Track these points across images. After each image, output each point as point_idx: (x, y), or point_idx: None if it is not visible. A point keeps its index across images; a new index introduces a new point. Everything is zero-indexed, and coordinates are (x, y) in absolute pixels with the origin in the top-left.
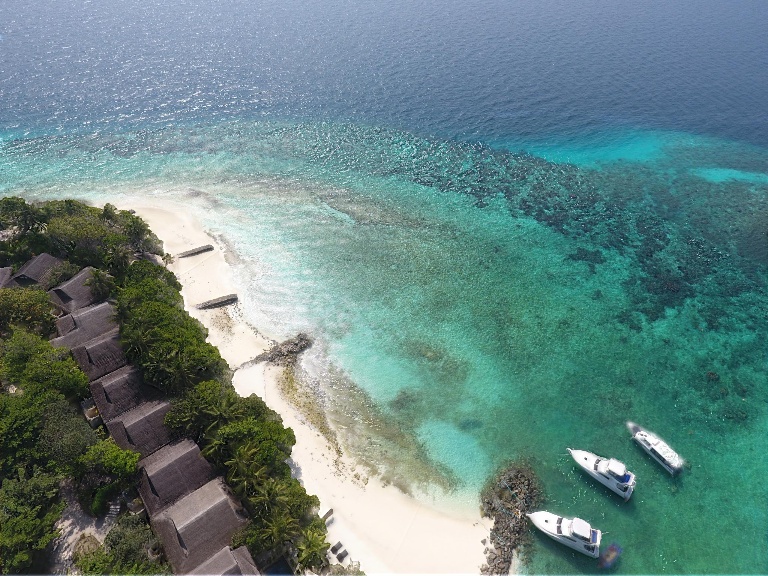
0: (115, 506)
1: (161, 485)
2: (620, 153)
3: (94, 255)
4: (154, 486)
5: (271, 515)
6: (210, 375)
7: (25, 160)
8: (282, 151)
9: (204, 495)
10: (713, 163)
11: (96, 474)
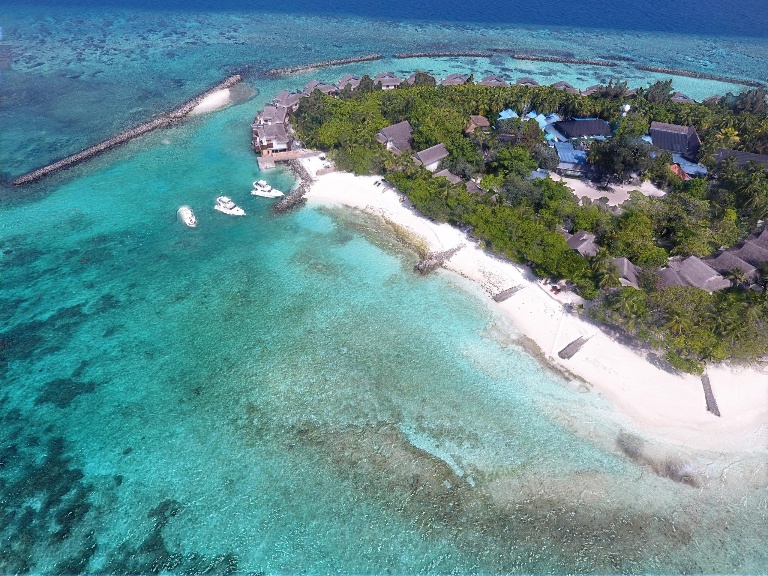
0: None
1: None
2: None
3: None
4: None
5: None
6: None
7: None
8: None
9: None
10: None
11: None
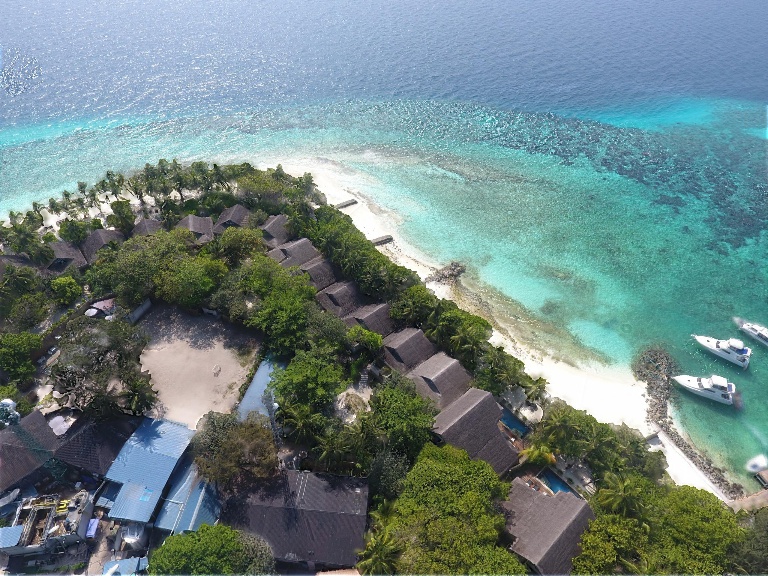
0: (364, 375)
1: (404, 355)
2: (677, 118)
3: (274, 206)
4: (400, 355)
5: (501, 366)
6: (411, 284)
7: (168, 139)
8: (382, 125)
9: (437, 361)
10: (763, 123)
11: (339, 356)
